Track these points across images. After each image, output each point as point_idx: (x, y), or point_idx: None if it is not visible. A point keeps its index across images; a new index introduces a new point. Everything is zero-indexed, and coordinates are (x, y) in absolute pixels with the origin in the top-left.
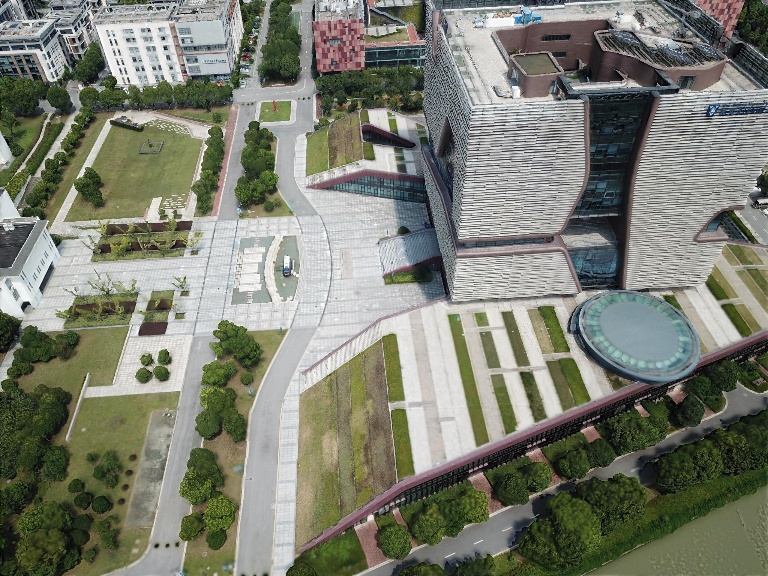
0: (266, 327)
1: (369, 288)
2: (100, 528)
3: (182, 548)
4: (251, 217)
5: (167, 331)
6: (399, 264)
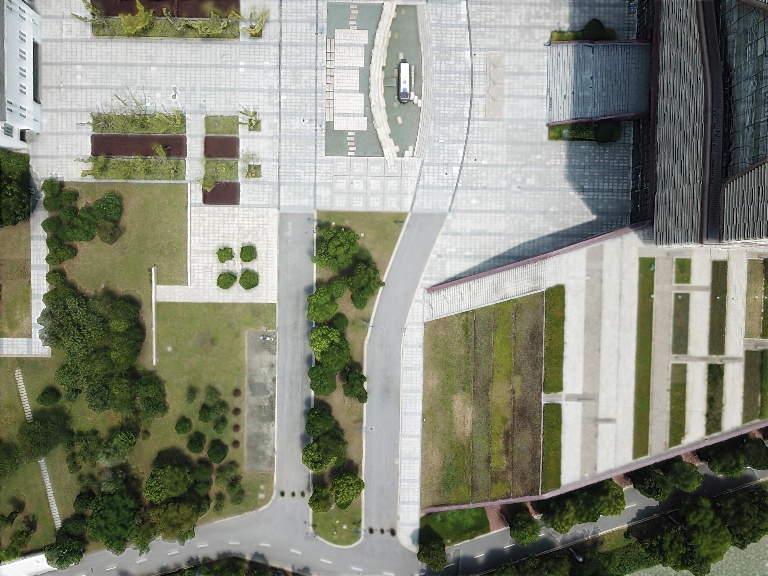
0: (378, 206)
1: (524, 144)
2: (224, 484)
3: (308, 498)
4: None
5: (242, 199)
6: (576, 105)
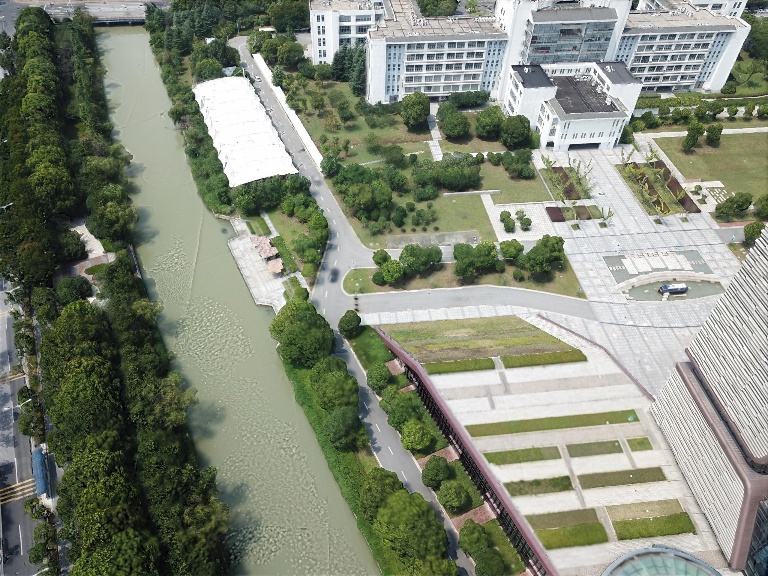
0: (584, 283)
1: (673, 361)
2: (381, 221)
3: (374, 266)
4: (734, 252)
5: (556, 223)
6: None
